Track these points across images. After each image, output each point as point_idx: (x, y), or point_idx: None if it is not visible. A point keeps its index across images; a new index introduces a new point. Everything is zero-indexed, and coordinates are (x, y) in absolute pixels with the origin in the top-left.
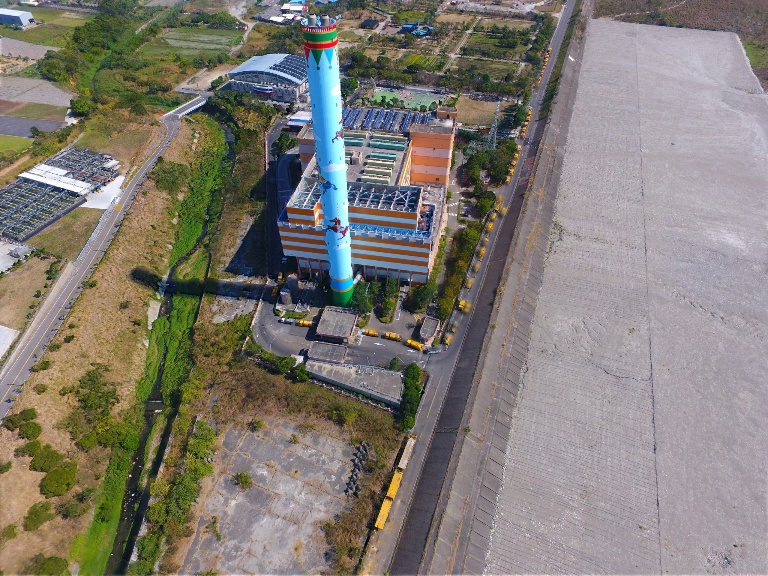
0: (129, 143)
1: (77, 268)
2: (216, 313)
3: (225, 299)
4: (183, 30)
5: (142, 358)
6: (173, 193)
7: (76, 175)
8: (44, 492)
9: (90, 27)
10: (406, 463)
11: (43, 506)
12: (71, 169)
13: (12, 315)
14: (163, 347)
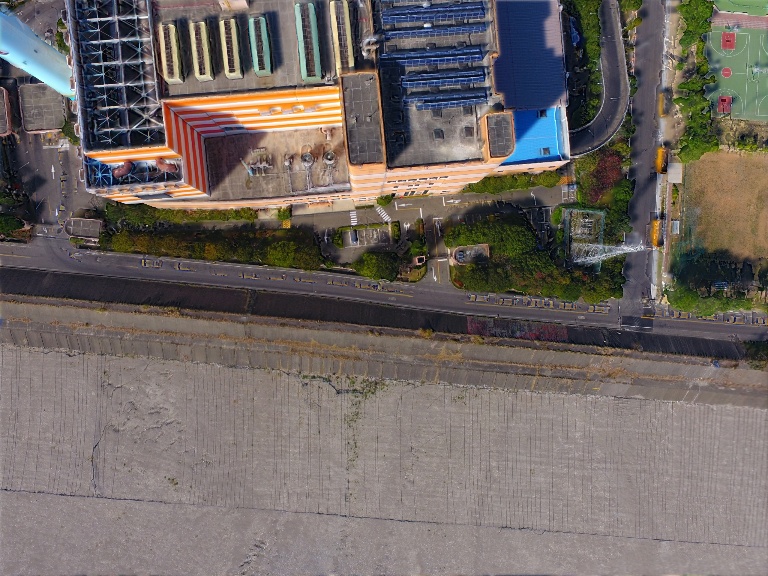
0: None
1: None
2: None
3: None
4: None
5: None
6: None
7: None
8: None
9: None
10: None
11: None
12: None
13: None
14: None
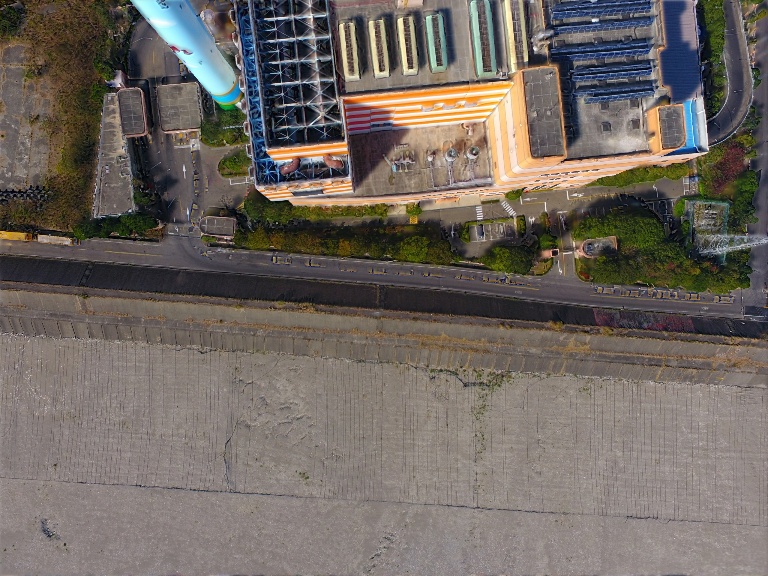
0: None
1: None
2: None
3: None
4: None
5: None
6: None
7: None
8: None
9: None
10: (44, 241)
11: None
12: None
13: None
14: None
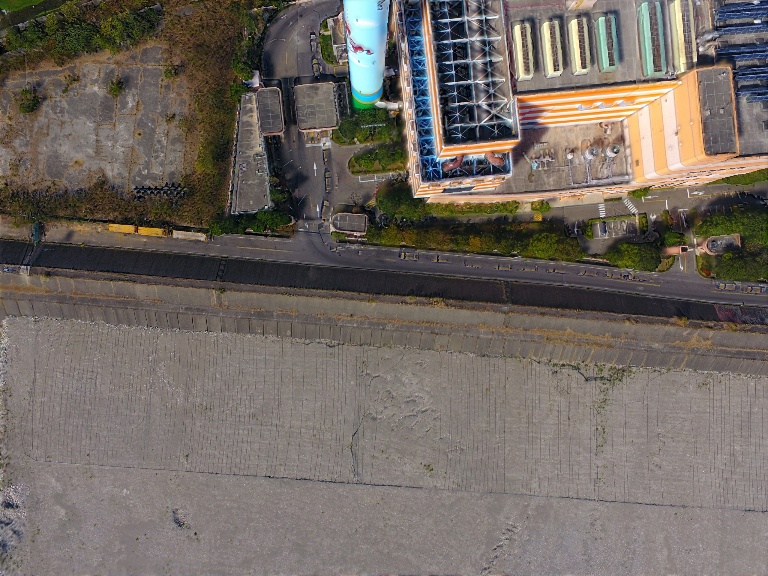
0: None
1: None
2: None
3: None
4: None
5: None
6: None
7: None
8: None
9: None
10: (179, 237)
11: None
12: None
13: None
14: None
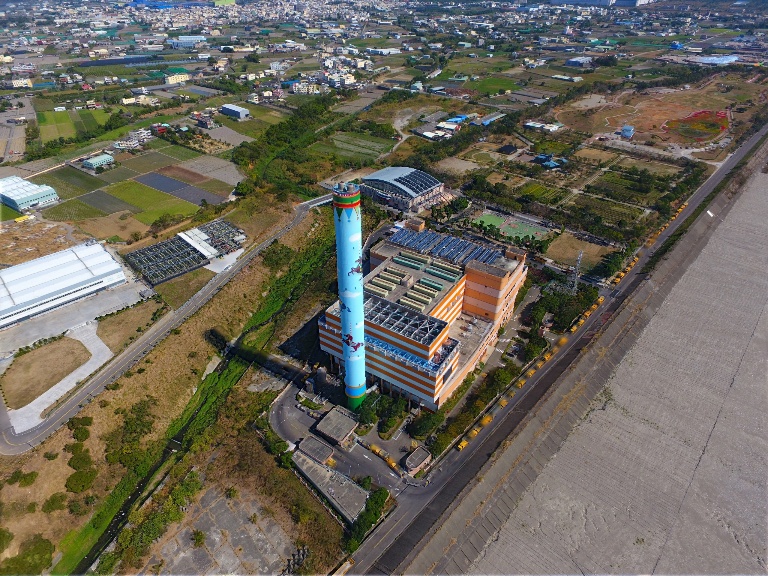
0: (261, 223)
1: (176, 316)
2: (253, 382)
3: (266, 372)
4: (351, 134)
5: (185, 402)
6: (273, 271)
7: (213, 241)
8: (67, 486)
9: (282, 126)
10: None
11: (62, 496)
12: (213, 236)
13: (117, 341)
14: (204, 398)
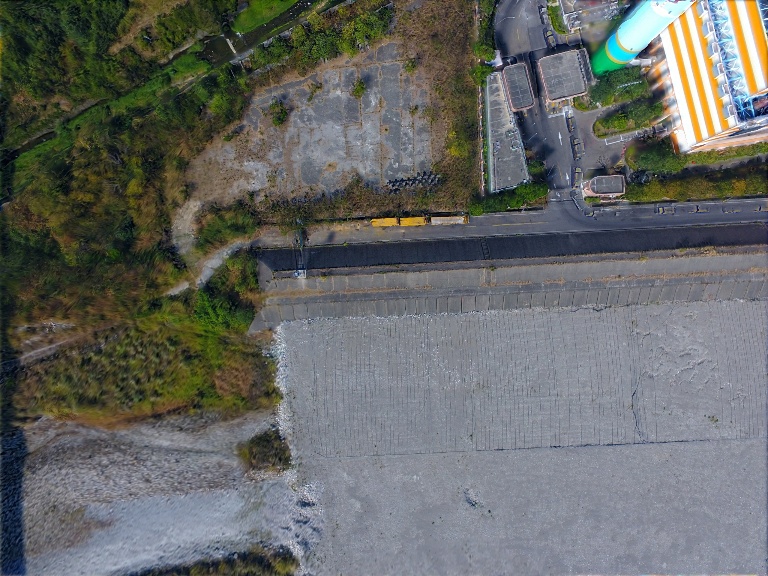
0: None
1: None
2: None
3: None
4: None
5: None
6: None
7: None
8: None
9: None
10: (438, 223)
11: None
12: None
13: None
14: None
